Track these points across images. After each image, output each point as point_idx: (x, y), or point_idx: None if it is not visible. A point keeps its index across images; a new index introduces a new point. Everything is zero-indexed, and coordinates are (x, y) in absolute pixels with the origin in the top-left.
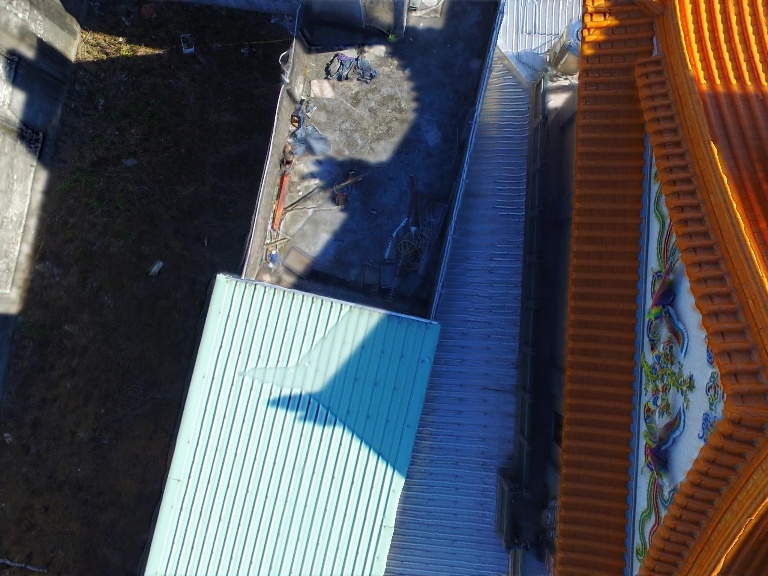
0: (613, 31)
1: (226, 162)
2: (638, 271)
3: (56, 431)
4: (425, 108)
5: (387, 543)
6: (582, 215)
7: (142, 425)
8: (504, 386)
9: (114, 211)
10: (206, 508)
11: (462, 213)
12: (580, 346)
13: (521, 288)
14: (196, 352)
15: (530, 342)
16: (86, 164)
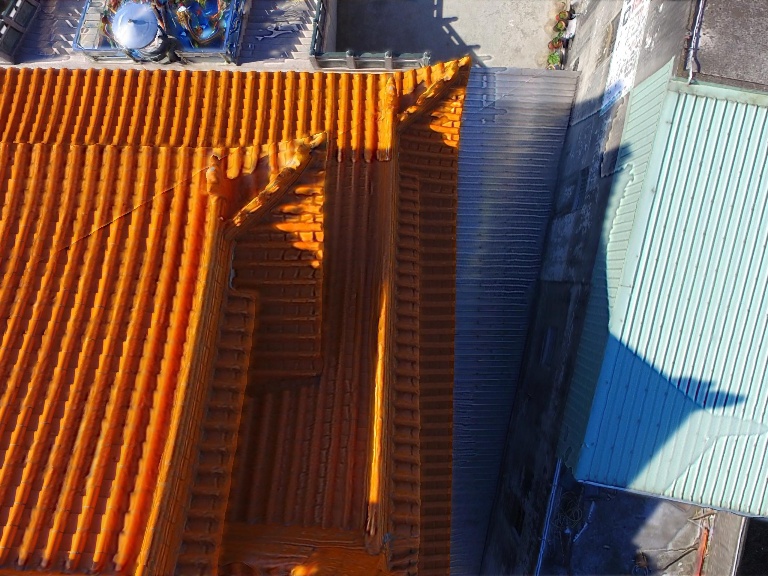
0: None
1: None
2: None
3: None
4: None
5: (629, 271)
6: None
7: None
8: None
9: None
10: None
11: (482, 504)
12: (443, 464)
13: None
14: None
15: None
16: None
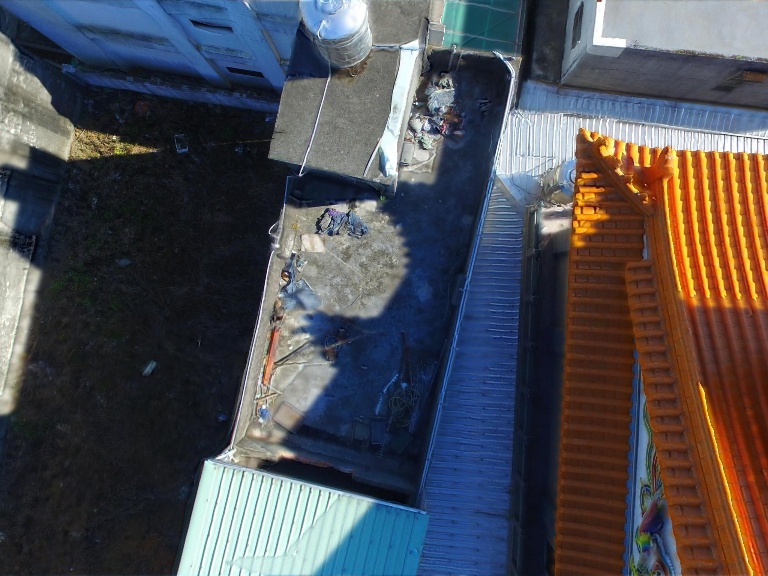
0: (603, 225)
1: (220, 262)
2: (627, 470)
3: (49, 530)
4: (416, 264)
5: None
6: (572, 408)
7: (135, 525)
8: (497, 510)
9: (107, 311)
10: None
11: None
12: (569, 540)
13: (514, 413)
14: (183, 541)
15: (522, 475)
16: (79, 263)
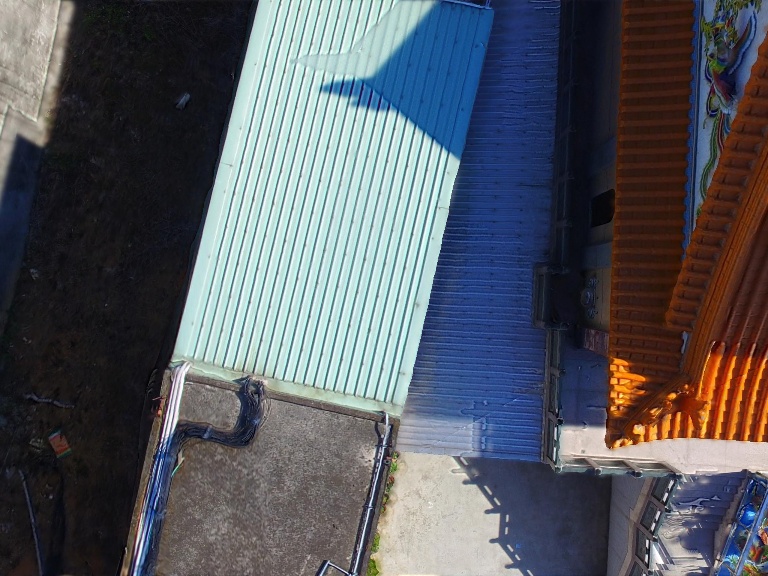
0: None
1: None
2: None
3: (83, 266)
4: None
5: (442, 224)
6: None
7: (169, 259)
8: (540, 181)
9: (141, 43)
10: (259, 193)
11: (497, 10)
12: (636, 26)
13: (557, 81)
14: (247, 40)
15: (568, 122)
16: None
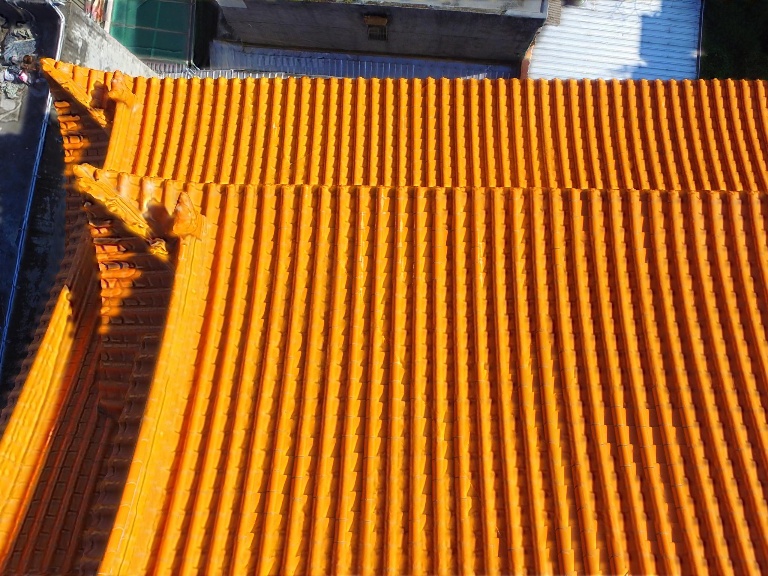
0: (87, 152)
1: None
2: None
3: None
4: (6, 210)
5: None
6: None
7: None
8: None
9: None
10: None
11: None
12: None
13: None
14: None
15: None
16: None
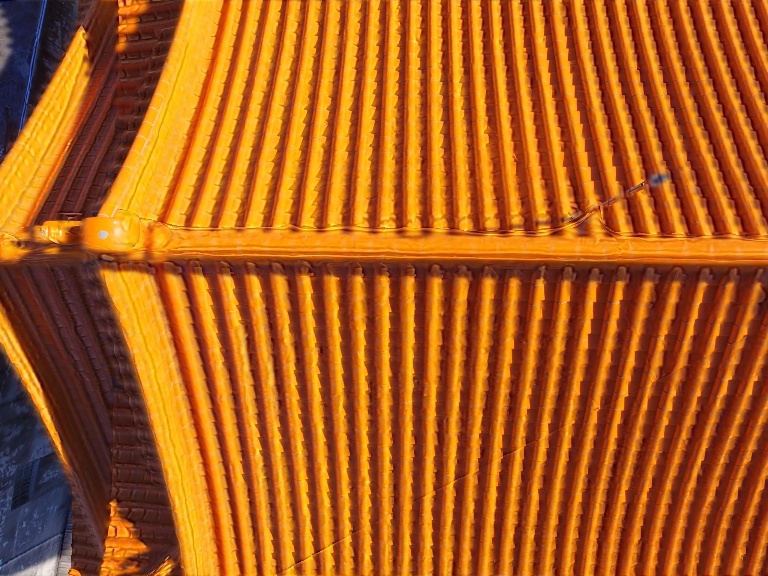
0: None
1: None
2: None
3: None
4: (17, 41)
5: None
6: None
7: None
8: None
9: None
10: None
11: None
12: None
13: None
14: None
15: None
16: None
